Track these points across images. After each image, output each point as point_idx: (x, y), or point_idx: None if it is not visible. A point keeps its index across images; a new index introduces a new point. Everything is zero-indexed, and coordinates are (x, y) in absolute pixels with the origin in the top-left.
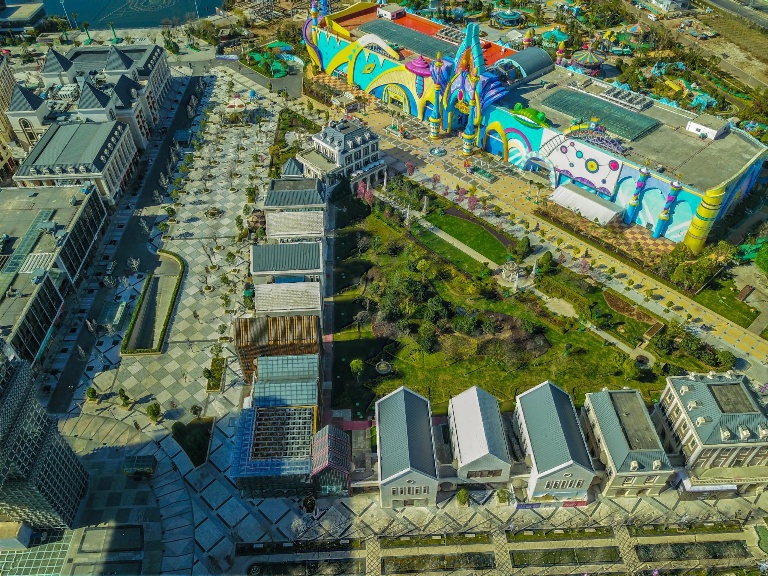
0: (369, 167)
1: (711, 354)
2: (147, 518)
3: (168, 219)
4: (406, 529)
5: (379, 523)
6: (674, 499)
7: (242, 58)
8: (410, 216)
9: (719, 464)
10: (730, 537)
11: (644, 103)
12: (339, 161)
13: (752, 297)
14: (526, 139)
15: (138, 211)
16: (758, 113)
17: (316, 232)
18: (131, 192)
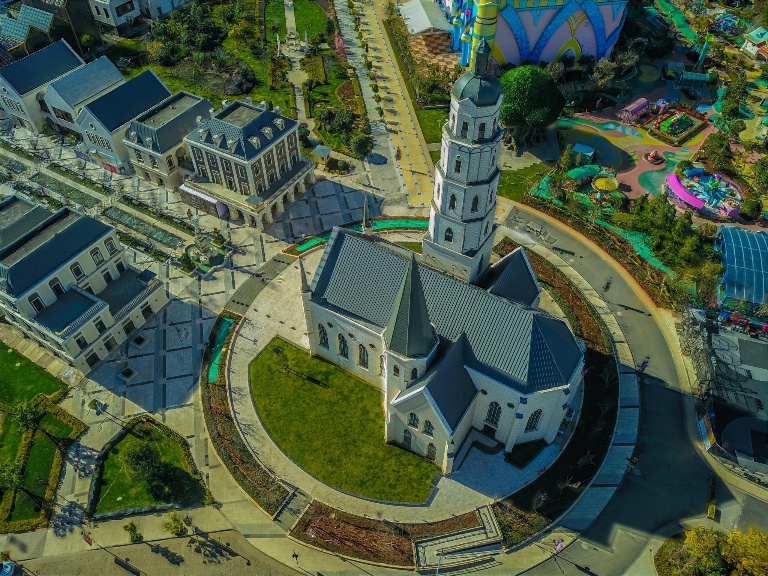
0: None
1: (351, 137)
2: None
3: None
4: (6, 136)
5: None
6: (179, 199)
7: None
8: None
9: (220, 181)
10: (179, 234)
11: None
12: None
13: None
14: None
15: None
16: (766, 15)
17: None
18: None
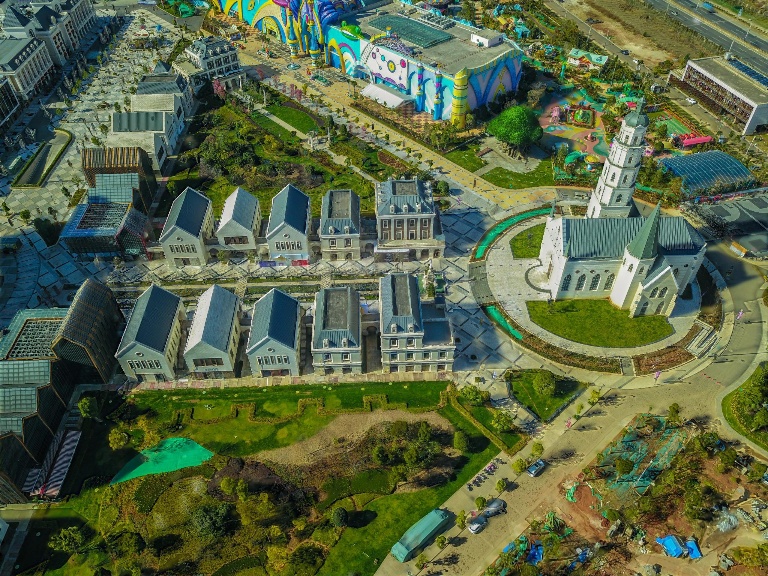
0: (229, 73)
1: (434, 184)
2: (8, 272)
3: (68, 110)
4: (181, 277)
5: (164, 274)
6: (370, 262)
7: (159, 3)
8: (254, 107)
9: (400, 237)
10: None
11: (447, 23)
12: (202, 65)
13: (488, 155)
14: (352, 51)
15: (47, 105)
16: (561, 40)
17: (168, 109)
18: (44, 93)
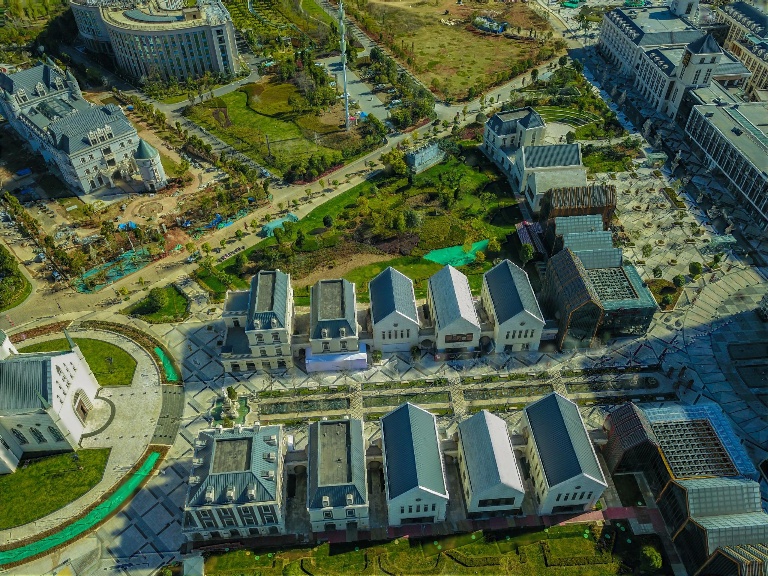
0: None
1: None
2: None
3: None
4: None
5: None
6: (301, 445)
7: None
8: None
9: None
10: (268, 417)
11: None
12: None
13: None
14: None
15: None
16: None
17: None
18: None
